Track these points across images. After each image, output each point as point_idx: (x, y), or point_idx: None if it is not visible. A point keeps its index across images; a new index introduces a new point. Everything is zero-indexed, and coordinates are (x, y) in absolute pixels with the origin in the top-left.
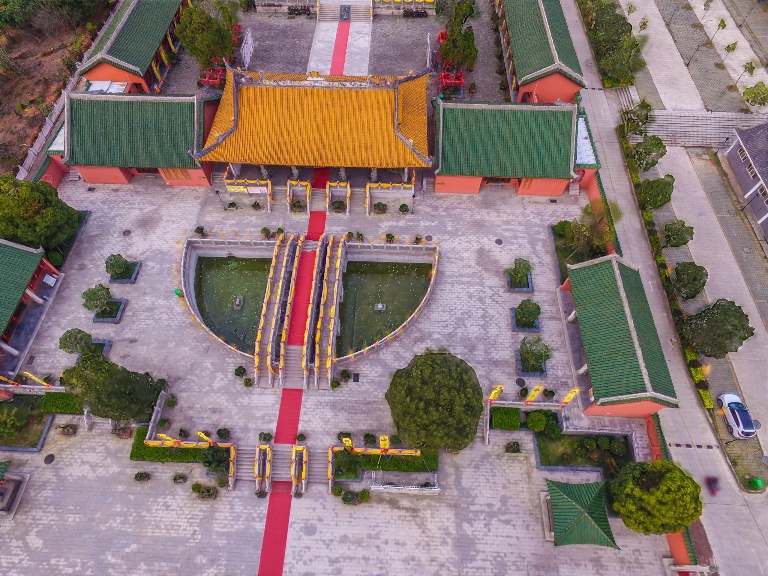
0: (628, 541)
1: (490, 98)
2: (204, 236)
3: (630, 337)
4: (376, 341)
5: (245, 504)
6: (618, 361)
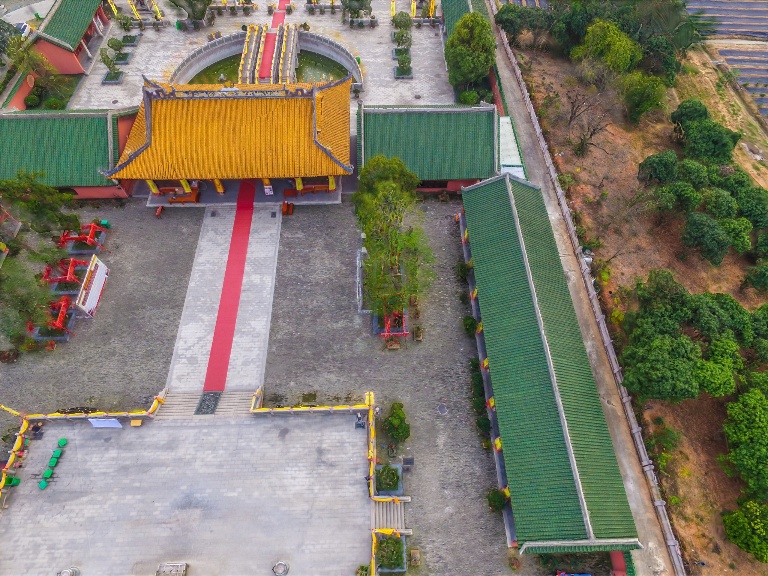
0: (118, 3)
1: (43, 235)
2: (355, 97)
3: (62, 4)
4: (229, 65)
5: (301, 6)
6: (77, 2)
